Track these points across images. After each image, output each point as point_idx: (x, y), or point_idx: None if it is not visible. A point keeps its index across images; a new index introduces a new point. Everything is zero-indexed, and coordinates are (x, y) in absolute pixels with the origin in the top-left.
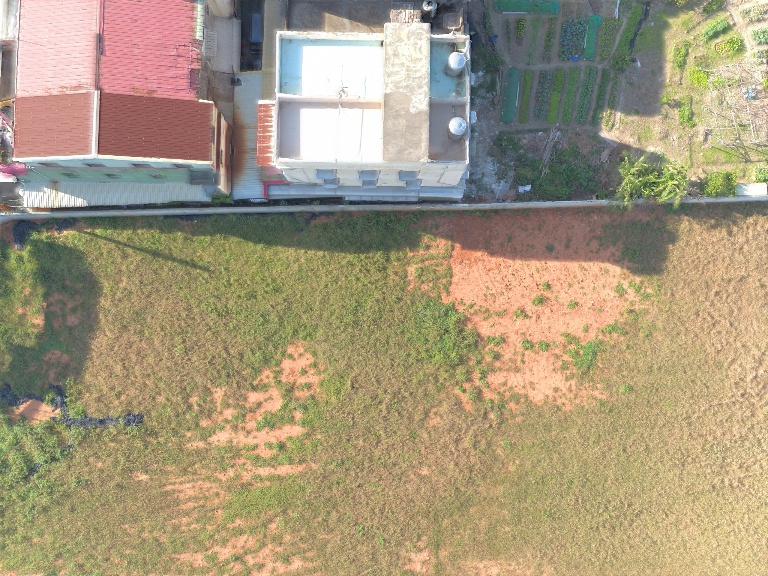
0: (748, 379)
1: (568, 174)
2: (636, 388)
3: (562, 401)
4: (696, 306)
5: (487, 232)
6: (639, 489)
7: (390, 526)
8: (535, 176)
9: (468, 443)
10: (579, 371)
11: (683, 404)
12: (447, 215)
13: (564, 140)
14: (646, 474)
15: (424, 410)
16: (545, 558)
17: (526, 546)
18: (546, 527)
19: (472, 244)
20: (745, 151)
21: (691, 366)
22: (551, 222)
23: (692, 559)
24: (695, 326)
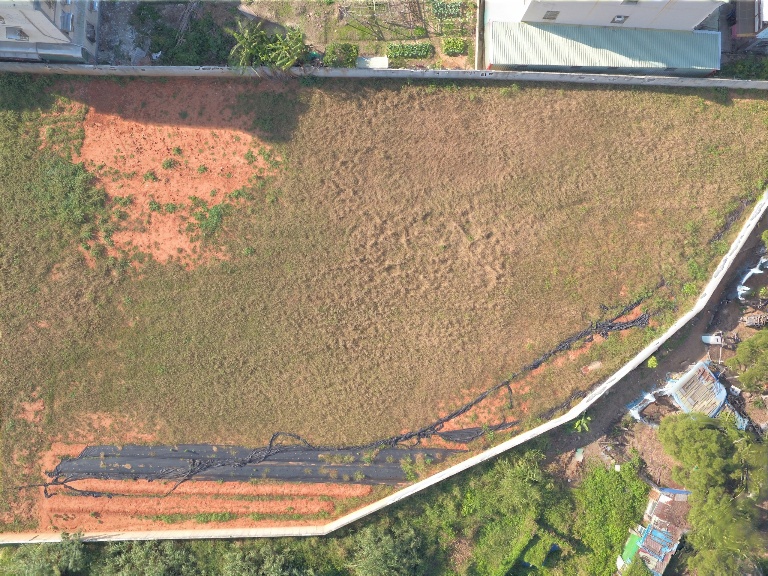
0: (367, 245)
1: (200, 43)
2: (258, 251)
3: (186, 261)
4: (321, 175)
5: (121, 97)
6: (255, 347)
7: (4, 375)
8: (168, 44)
9: (88, 298)
10: (203, 233)
11: (303, 268)
12: (82, 79)
13: (199, 10)
14: (264, 333)
15: (46, 265)
16: (159, 411)
17: (140, 399)
18: (161, 381)
19: (105, 108)
20: (379, 30)
21: (313, 232)
22: (186, 90)
23: (304, 416)
24: (320, 194)
